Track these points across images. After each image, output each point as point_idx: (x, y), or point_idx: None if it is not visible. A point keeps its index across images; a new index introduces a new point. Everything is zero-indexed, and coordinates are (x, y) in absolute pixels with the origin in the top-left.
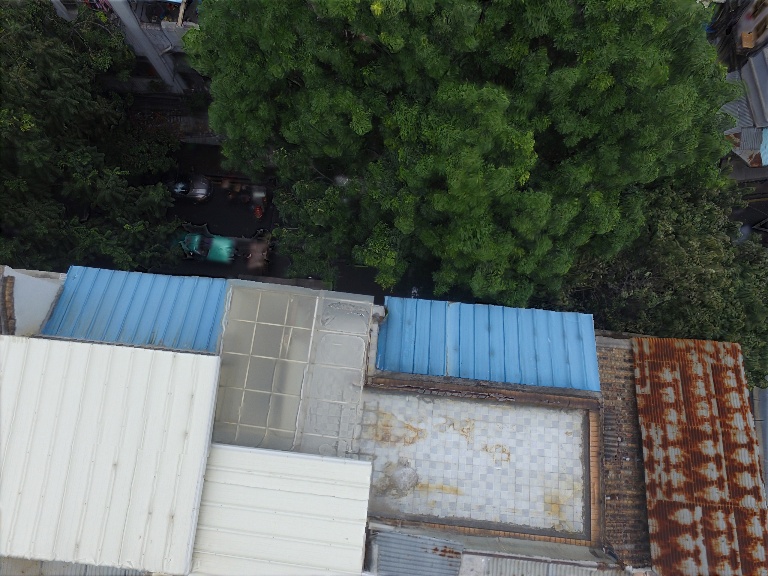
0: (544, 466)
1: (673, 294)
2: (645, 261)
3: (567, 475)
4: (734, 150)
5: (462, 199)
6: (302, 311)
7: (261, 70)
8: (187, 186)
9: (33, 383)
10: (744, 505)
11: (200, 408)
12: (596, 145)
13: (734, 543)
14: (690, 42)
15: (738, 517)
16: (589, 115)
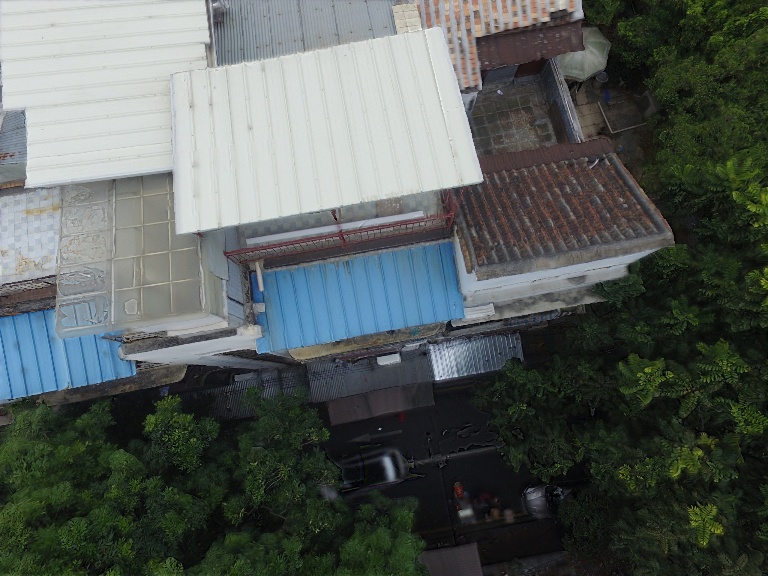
0: None
1: None
2: None
3: None
4: None
5: None
6: None
7: None
8: None
9: (344, 168)
10: None
11: (185, 189)
12: None
13: None
14: None
15: None
16: None
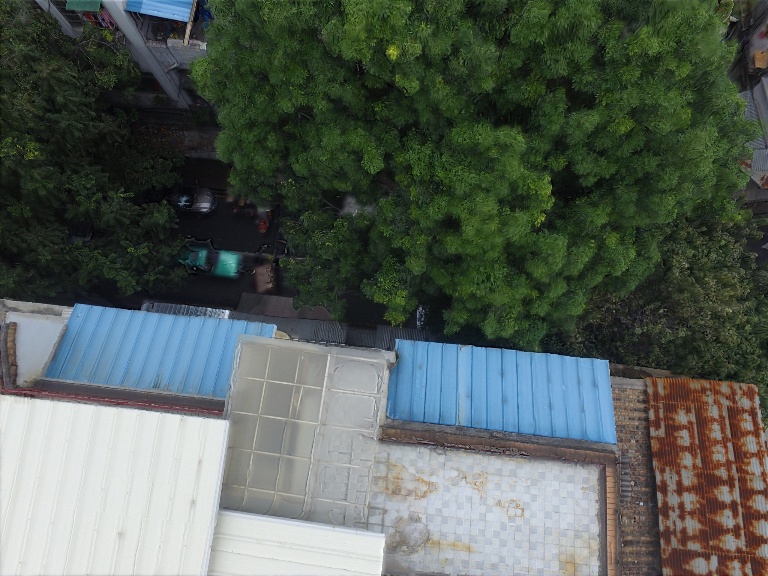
0: (559, 523)
1: (687, 330)
2: (659, 296)
3: (583, 533)
4: (745, 171)
5: (476, 243)
6: (313, 367)
7: (270, 102)
8: (191, 199)
9: (35, 446)
10: (761, 554)
11: (207, 475)
12: (613, 185)
13: None
14: (711, 82)
15: (755, 567)
16: (607, 156)
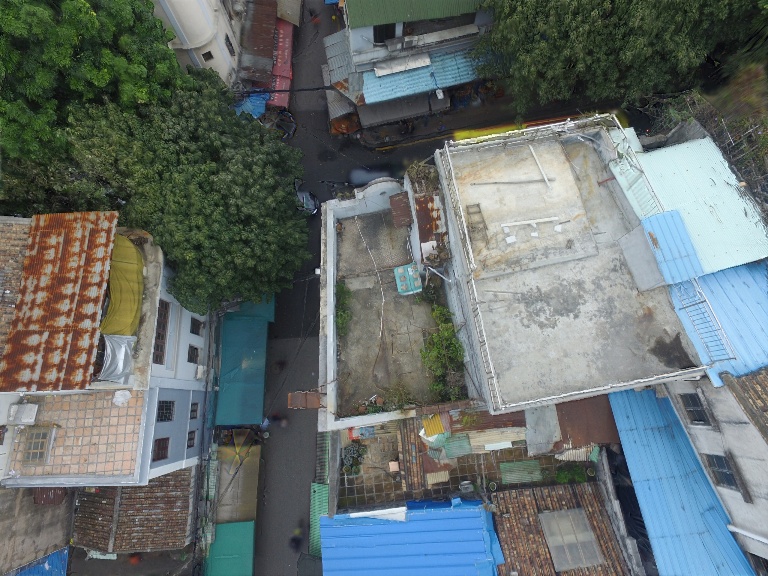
0: None
1: (113, 187)
2: None
3: None
4: (345, 93)
5: None
6: None
7: None
8: None
9: None
10: (82, 326)
11: None
12: None
13: (65, 354)
14: None
15: (74, 336)
16: None
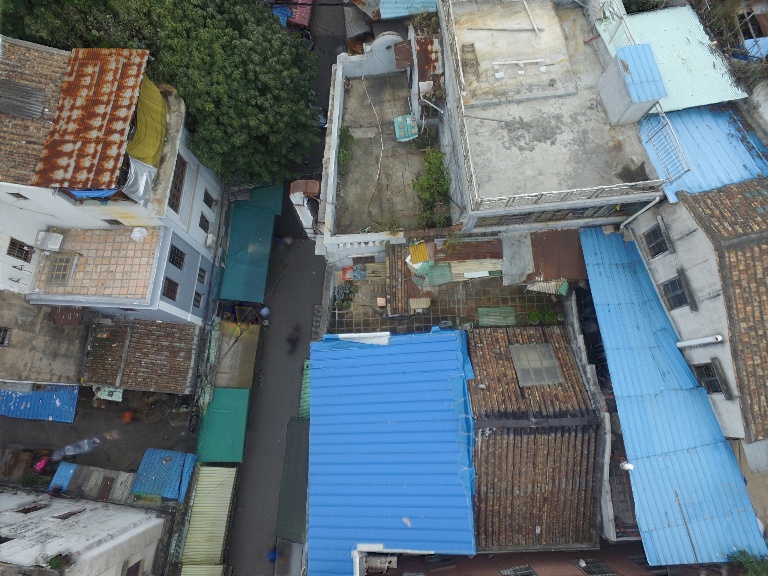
0: None
1: (145, 39)
2: None
3: None
4: (362, 8)
5: None
6: None
7: None
8: None
9: None
10: (111, 139)
11: None
12: None
13: (95, 160)
14: None
15: (104, 146)
16: None
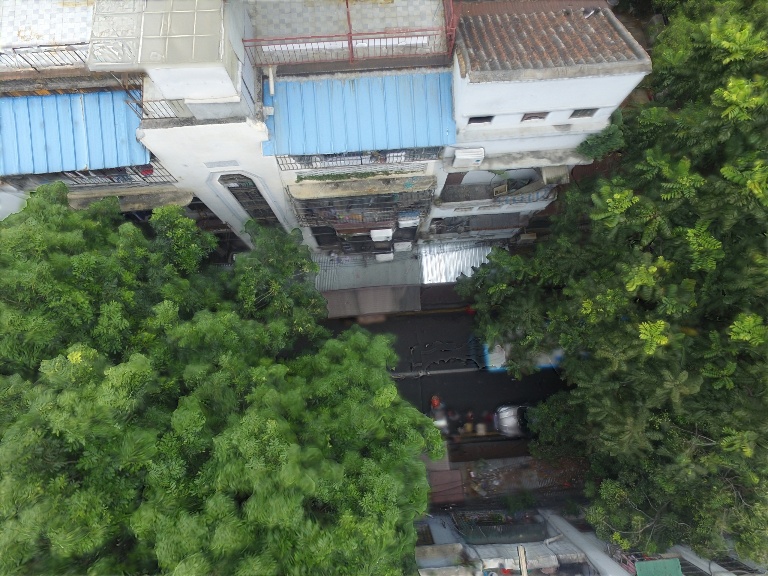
0: None
1: None
2: None
3: None
4: None
5: None
6: None
7: None
8: (526, 424)
9: None
10: None
11: None
12: None
13: None
14: None
15: None
16: None
